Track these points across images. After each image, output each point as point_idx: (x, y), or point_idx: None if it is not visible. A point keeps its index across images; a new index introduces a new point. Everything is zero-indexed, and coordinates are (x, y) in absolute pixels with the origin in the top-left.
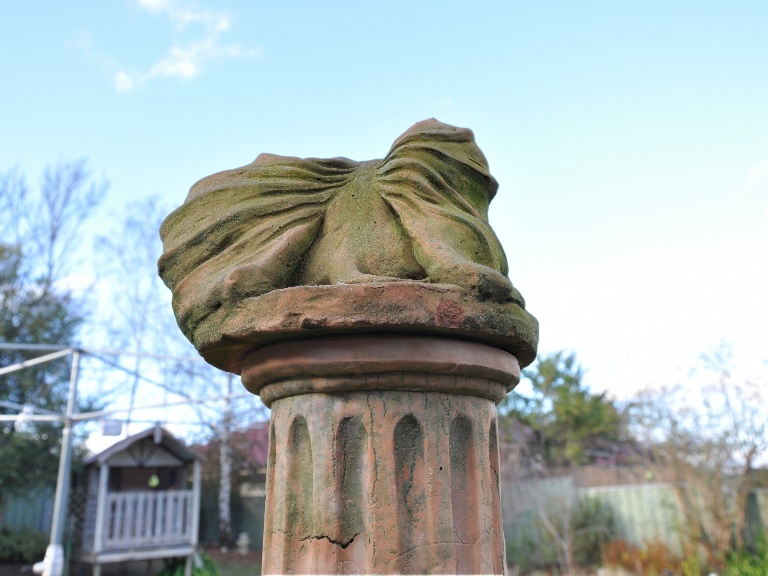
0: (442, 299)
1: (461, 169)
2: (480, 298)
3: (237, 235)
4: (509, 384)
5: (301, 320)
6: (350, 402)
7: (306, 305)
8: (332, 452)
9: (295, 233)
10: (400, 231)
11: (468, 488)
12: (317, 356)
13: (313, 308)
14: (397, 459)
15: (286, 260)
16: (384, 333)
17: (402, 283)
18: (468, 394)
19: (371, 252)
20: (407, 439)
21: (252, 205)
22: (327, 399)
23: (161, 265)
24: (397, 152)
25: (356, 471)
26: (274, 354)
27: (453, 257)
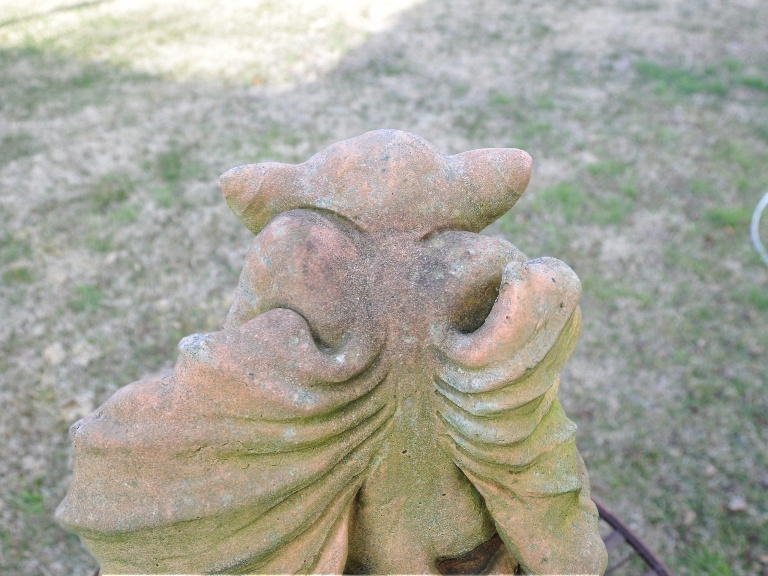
0: None
1: None
2: None
3: None
4: None
5: None
6: None
7: None
8: None
9: (341, 561)
10: (478, 502)
11: None
12: None
13: None
14: None
15: None
16: None
17: None
18: None
19: (442, 538)
20: None
21: (263, 546)
22: None
23: None
24: (488, 414)
25: None
26: None
27: None
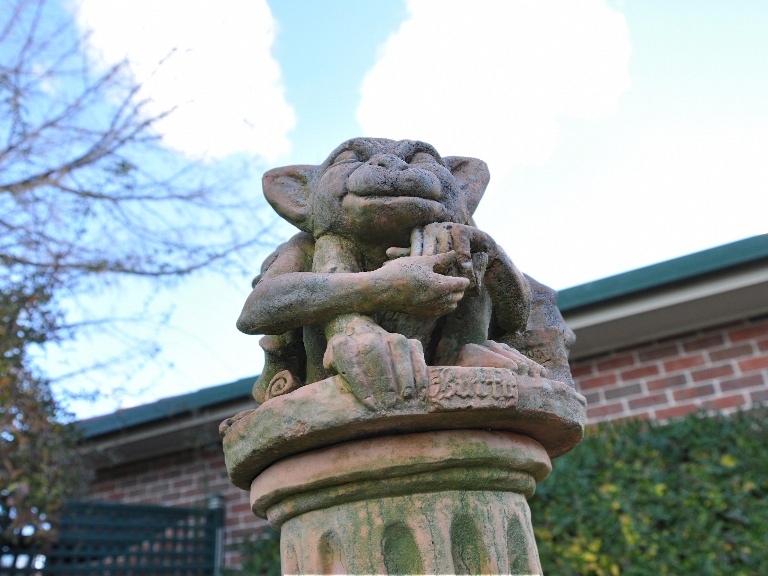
0: None
1: None
2: None
3: None
4: None
5: None
6: None
7: None
8: None
9: None
10: None
11: None
12: None
13: None
14: None
15: None
16: None
17: None
18: None
19: None
20: None
21: None
22: None
23: None
24: None
25: None
26: None
27: None
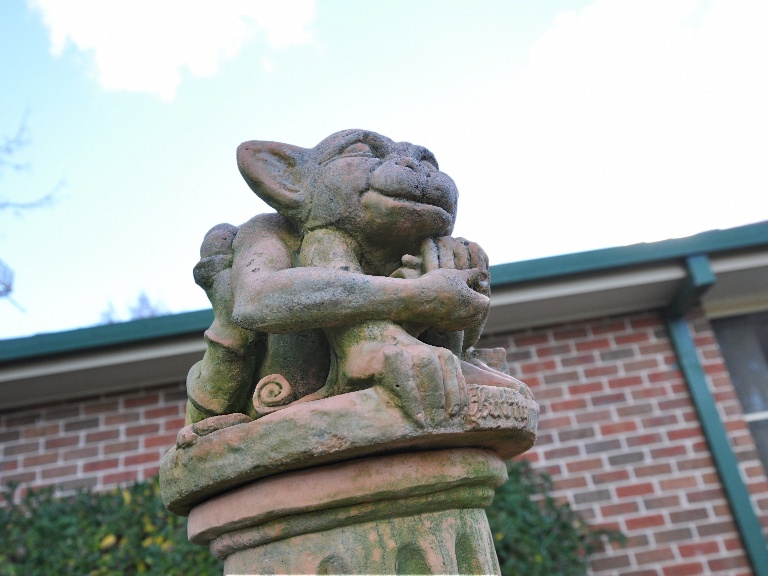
0: None
1: None
2: None
3: None
4: (207, 538)
5: None
6: None
7: None
8: None
9: None
10: None
11: None
12: None
13: None
14: None
15: None
16: None
17: None
18: None
19: None
20: None
21: None
22: None
23: None
24: None
25: None
26: None
27: None
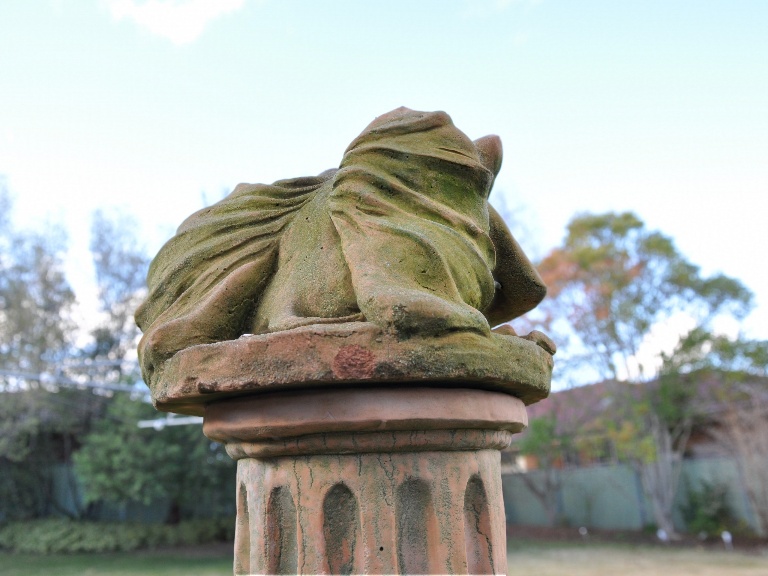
0: (343, 345)
1: (426, 164)
2: (402, 335)
3: (190, 283)
4: (496, 427)
5: (196, 385)
6: (279, 469)
7: (199, 368)
8: (264, 528)
9: (236, 274)
10: None
11: (430, 568)
12: (232, 421)
13: (205, 371)
14: (330, 537)
15: (225, 307)
16: (294, 390)
17: (289, 333)
18: (423, 450)
19: (312, 285)
20: (345, 511)
21: (201, 248)
22: (259, 465)
23: (137, 321)
24: (343, 160)
25: (293, 549)
26: (206, 417)
27: (373, 286)
